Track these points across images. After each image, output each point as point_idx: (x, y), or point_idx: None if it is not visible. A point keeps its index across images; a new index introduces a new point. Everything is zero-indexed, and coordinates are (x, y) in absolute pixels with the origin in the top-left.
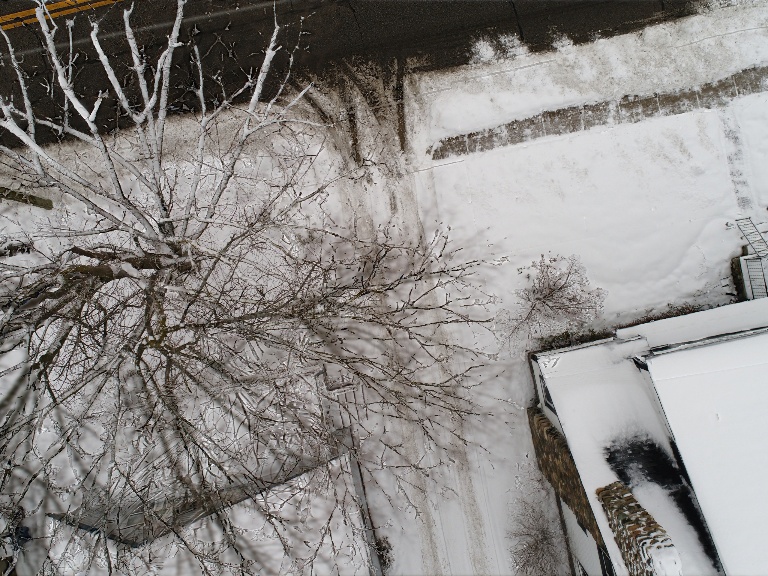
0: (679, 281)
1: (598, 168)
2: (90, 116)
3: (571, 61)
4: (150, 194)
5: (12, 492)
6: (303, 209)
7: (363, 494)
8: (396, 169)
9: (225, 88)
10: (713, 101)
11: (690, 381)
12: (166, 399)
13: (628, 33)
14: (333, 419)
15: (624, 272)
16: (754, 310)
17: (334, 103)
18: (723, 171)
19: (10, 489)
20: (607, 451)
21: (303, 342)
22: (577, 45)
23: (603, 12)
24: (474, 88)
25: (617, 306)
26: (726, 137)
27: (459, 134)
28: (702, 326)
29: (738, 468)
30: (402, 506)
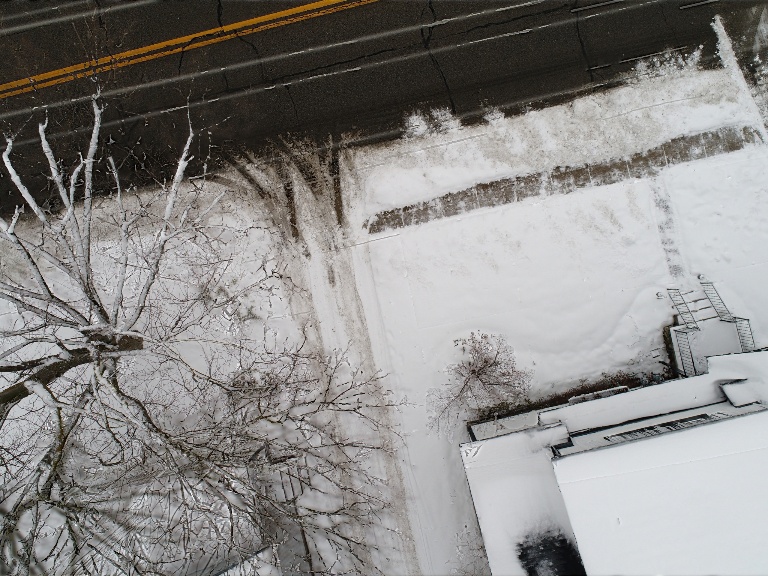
0: (613, 350)
1: (531, 240)
2: (9, 229)
3: (502, 135)
4: None
5: None
6: (242, 286)
7: (307, 565)
8: (333, 243)
9: None
10: (643, 171)
11: (593, 484)
12: None
13: (558, 105)
14: (276, 493)
15: (558, 342)
16: (673, 393)
17: (271, 179)
18: (654, 241)
19: None
20: (520, 547)
21: (245, 417)
22: (508, 118)
23: (533, 84)
24: (407, 163)
25: (552, 376)
26: (657, 206)
27: (394, 208)
28: (622, 409)
29: (636, 574)
30: (348, 574)
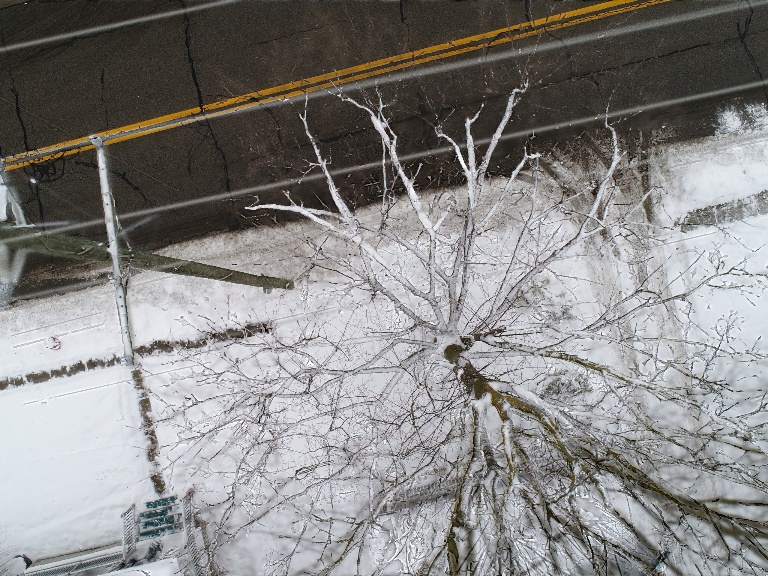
0: None
1: None
2: (435, 226)
3: None
4: (444, 287)
5: (257, 573)
6: (555, 286)
7: None
8: (644, 242)
9: (466, 164)
10: None
11: None
12: (525, 510)
13: None
14: None
15: None
16: None
17: (578, 177)
18: None
19: (255, 570)
20: None
21: None
22: None
23: None
24: (725, 160)
25: None
26: None
27: (708, 205)
28: None
29: None
30: None
